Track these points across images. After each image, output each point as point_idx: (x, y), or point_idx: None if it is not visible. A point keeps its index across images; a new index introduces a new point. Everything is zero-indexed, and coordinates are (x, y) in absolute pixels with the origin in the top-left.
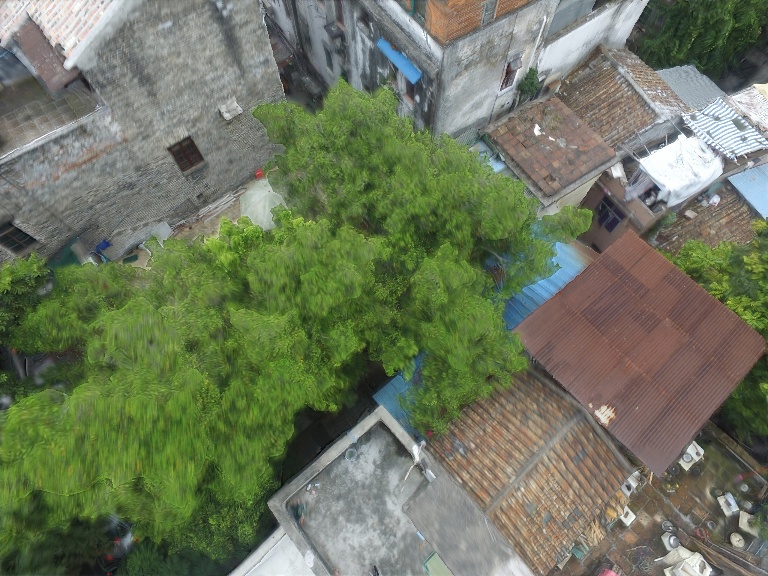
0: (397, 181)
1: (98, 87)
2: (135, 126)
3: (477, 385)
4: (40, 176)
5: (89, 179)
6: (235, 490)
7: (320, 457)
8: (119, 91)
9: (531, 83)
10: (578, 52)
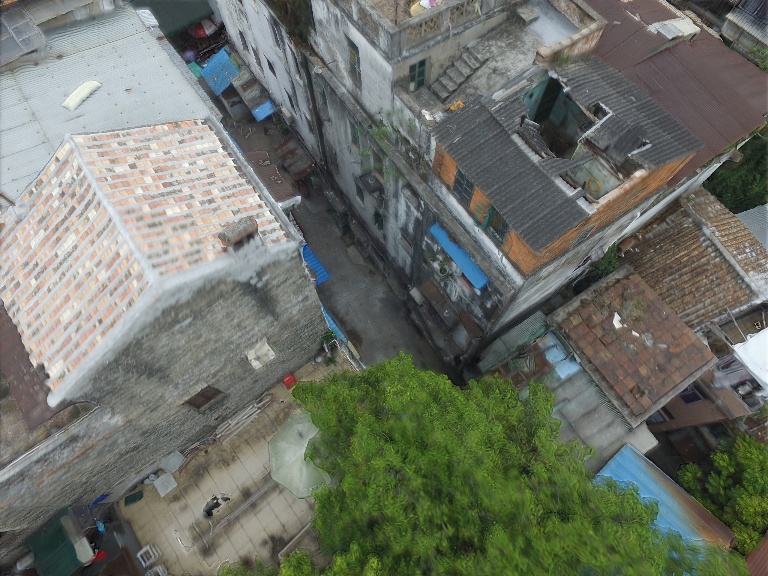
0: (495, 547)
1: (94, 400)
2: (142, 406)
3: None
4: (19, 490)
5: (83, 465)
6: None
7: None
8: (122, 392)
9: (608, 262)
10: (656, 210)
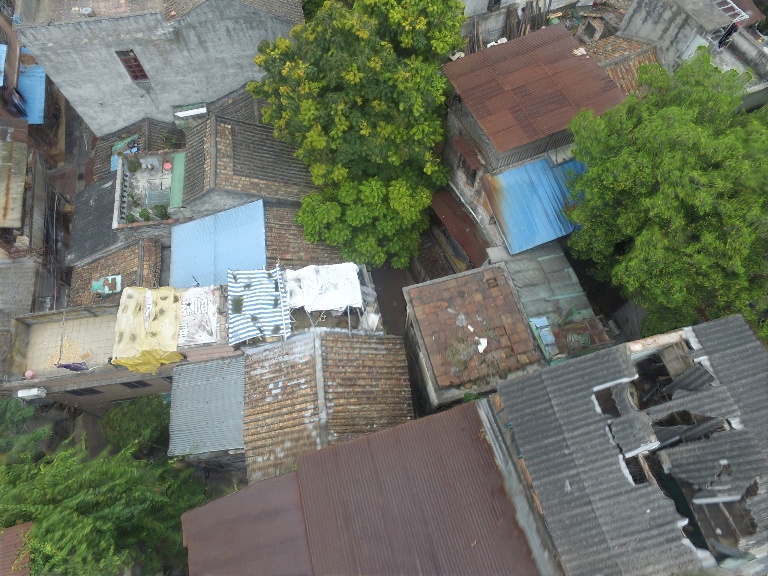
0: None
1: None
2: None
3: None
4: None
5: None
6: None
7: (765, 88)
8: None
9: None
10: None
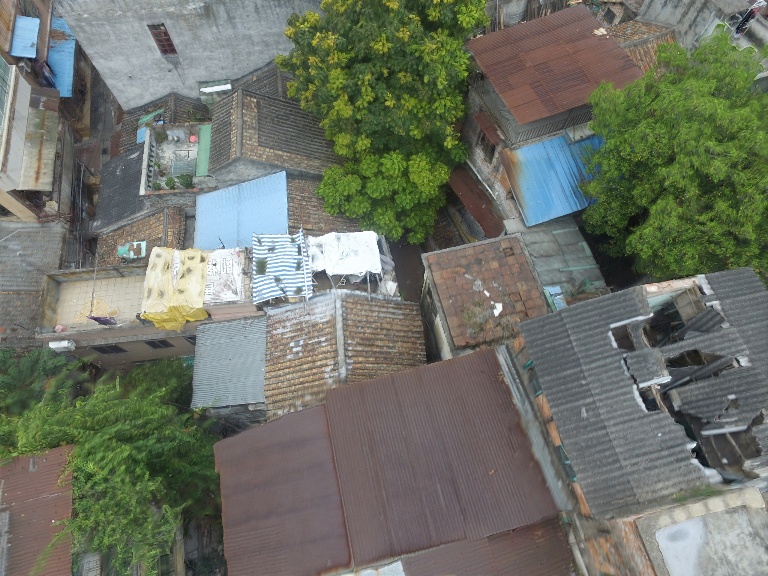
0: None
1: None
2: None
3: None
4: None
5: None
6: None
7: None
8: None
9: None
10: None
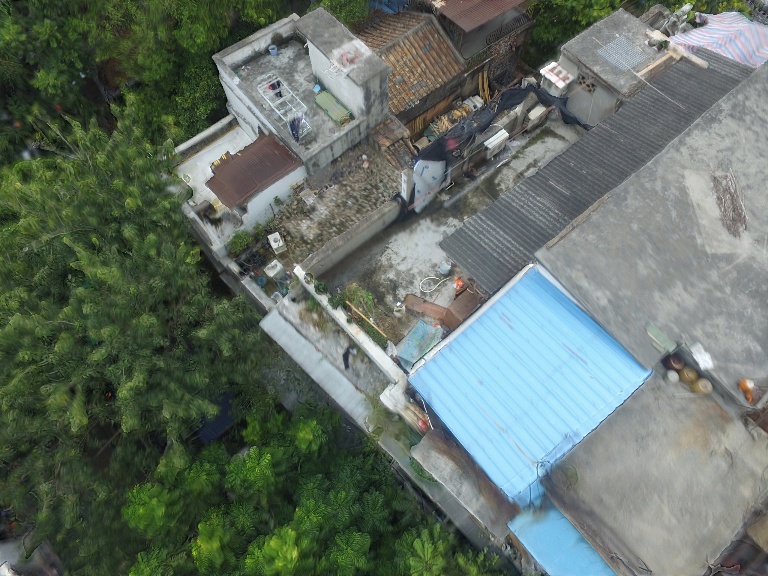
0: None
1: None
2: None
3: (362, 7)
4: None
5: None
6: (190, 40)
7: (249, 36)
8: None
9: None
10: None
